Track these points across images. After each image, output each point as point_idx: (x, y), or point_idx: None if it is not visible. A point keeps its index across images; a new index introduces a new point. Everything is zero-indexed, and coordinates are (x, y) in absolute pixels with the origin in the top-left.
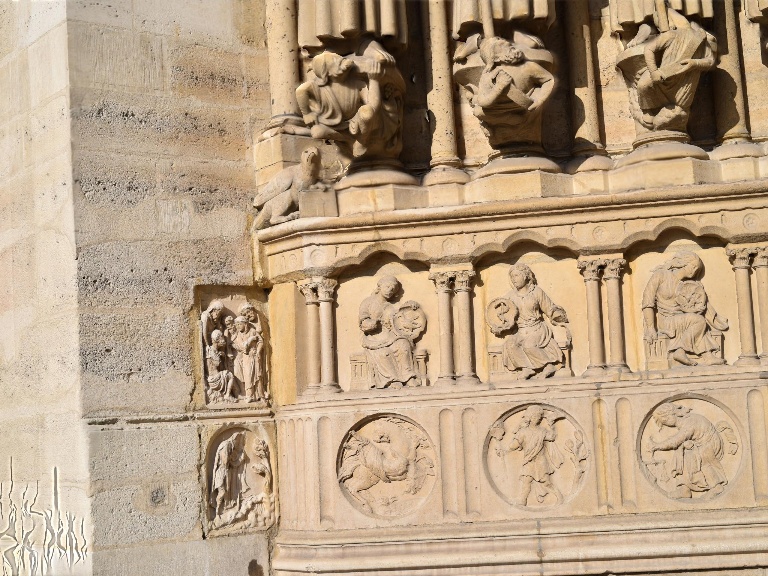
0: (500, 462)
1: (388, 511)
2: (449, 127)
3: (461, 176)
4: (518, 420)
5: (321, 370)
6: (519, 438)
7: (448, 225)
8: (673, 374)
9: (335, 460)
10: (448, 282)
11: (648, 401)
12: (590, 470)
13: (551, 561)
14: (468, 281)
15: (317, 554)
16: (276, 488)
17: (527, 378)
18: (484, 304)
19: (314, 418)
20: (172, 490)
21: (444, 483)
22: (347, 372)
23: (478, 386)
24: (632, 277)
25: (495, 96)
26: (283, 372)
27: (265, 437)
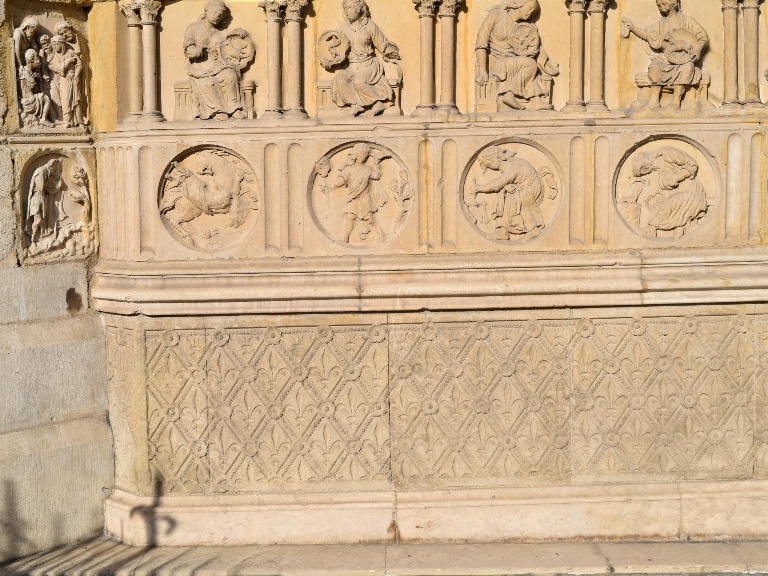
0: (324, 199)
1: (210, 244)
2: None
3: None
4: (344, 157)
5: (143, 97)
6: (344, 175)
7: None
8: (501, 117)
9: (156, 191)
10: (279, 10)
11: (474, 143)
12: (413, 210)
13: (370, 297)
14: (300, 11)
15: (136, 284)
16: (95, 217)
17: (356, 115)
18: (315, 36)
19: (135, 147)
20: None
21: (267, 218)
22: (171, 100)
23: (305, 121)
24: (467, 16)
25: None
26: (103, 97)
27: (84, 164)
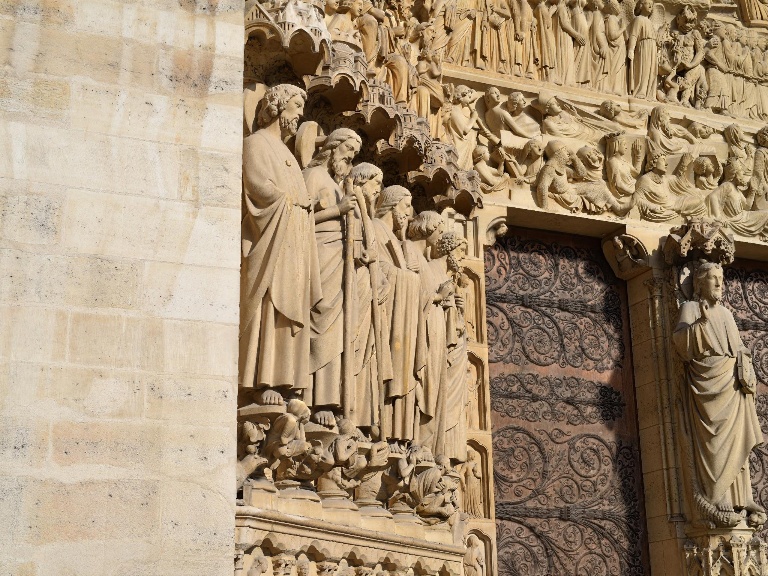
0: None
1: None
2: None
3: None
4: None
5: None
6: None
7: None
8: None
9: None
10: None
11: None
12: None
13: None
14: None
15: None
16: None
17: None
18: None
19: None
20: None
21: None
22: None
23: None
24: None
25: None
26: None
27: None
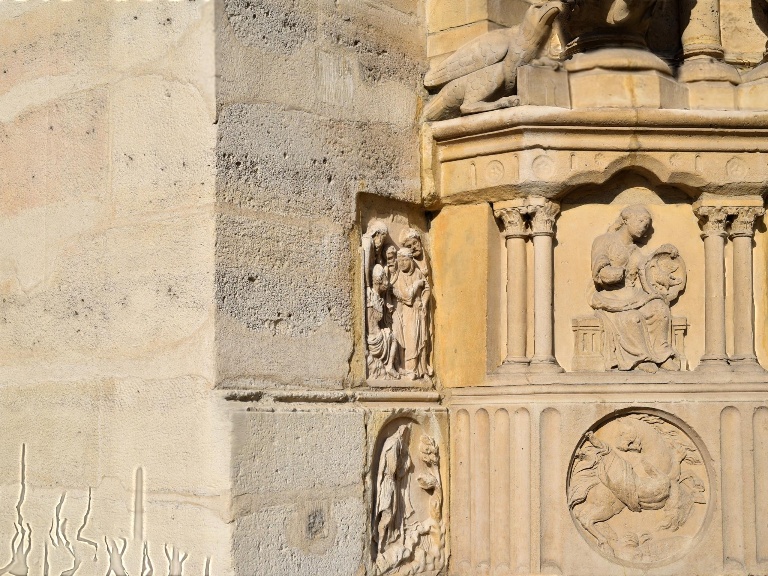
0: None
1: (638, 555)
2: (715, 3)
3: (734, 73)
4: None
5: (526, 337)
6: None
7: (737, 137)
8: None
9: (565, 475)
10: (724, 221)
11: None
12: None
13: None
14: (753, 222)
15: None
16: (447, 512)
17: None
18: (767, 258)
19: (535, 409)
20: (332, 513)
21: (724, 516)
22: (567, 343)
23: None
24: None
25: None
26: (458, 337)
27: (436, 434)
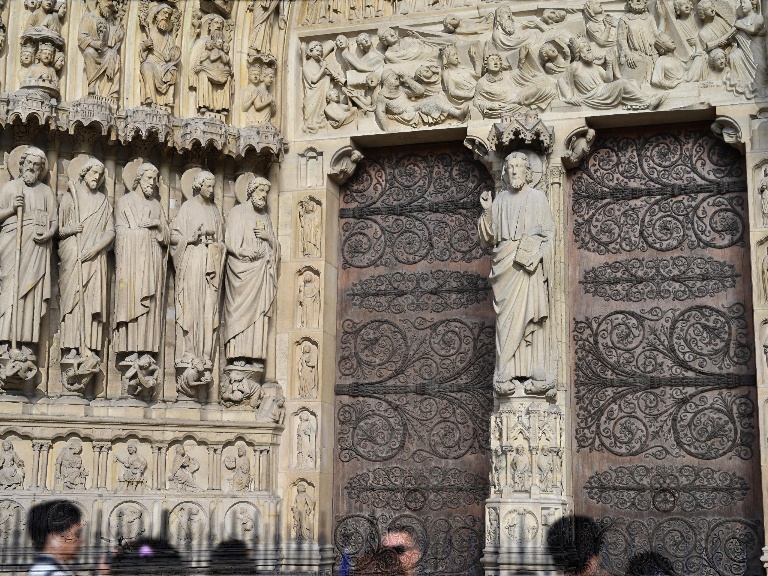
0: None
1: None
2: None
3: None
4: None
5: None
6: None
7: None
8: (65, 492)
9: None
10: None
11: (54, 502)
12: (27, 529)
13: (7, 565)
14: None
15: None
16: None
17: (5, 489)
18: None
19: None
20: None
21: None
22: None
23: None
24: (53, 450)
25: (13, 373)
26: None
27: None
